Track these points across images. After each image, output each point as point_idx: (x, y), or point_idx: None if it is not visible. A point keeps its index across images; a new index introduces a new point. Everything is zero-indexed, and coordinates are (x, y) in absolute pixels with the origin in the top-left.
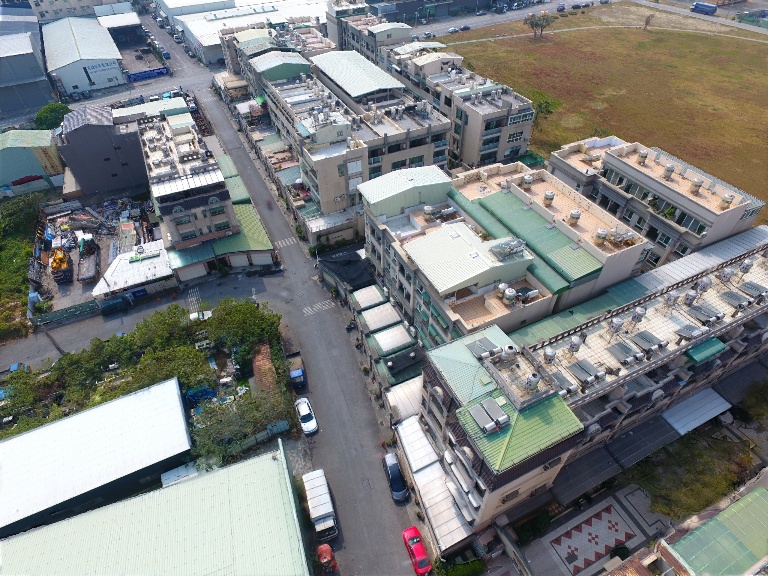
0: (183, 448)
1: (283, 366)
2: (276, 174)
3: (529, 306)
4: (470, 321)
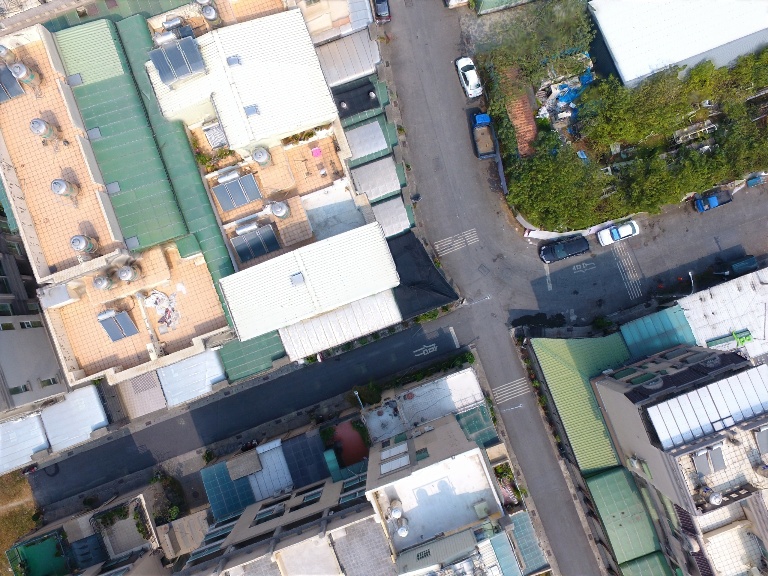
0: (596, 3)
1: (500, 102)
2: (546, 558)
3: (184, 8)
4: (268, 8)
